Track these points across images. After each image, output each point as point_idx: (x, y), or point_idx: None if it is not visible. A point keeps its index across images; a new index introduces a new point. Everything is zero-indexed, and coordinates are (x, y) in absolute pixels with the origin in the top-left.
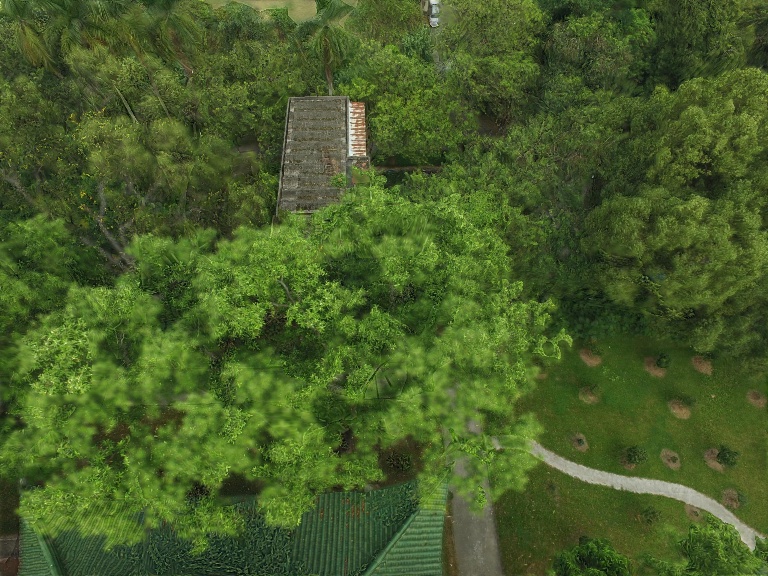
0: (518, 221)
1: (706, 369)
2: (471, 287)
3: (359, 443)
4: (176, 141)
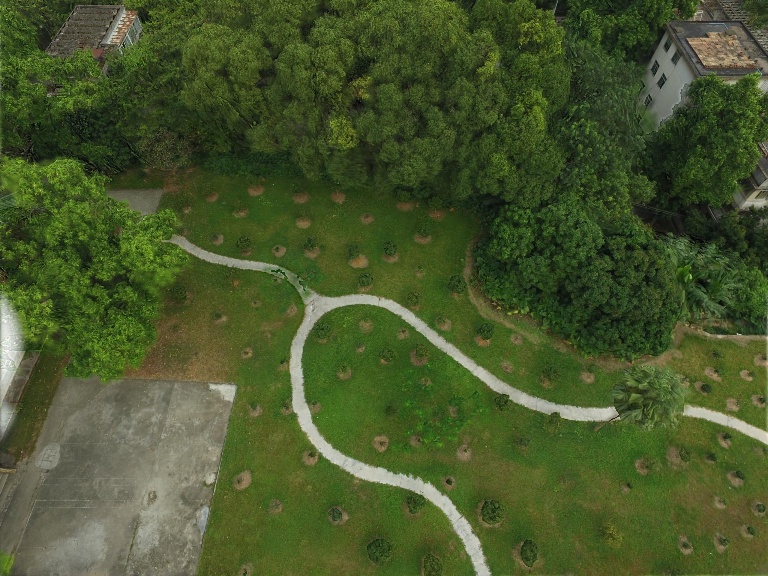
0: (158, 66)
1: (339, 200)
2: None
3: None
4: None
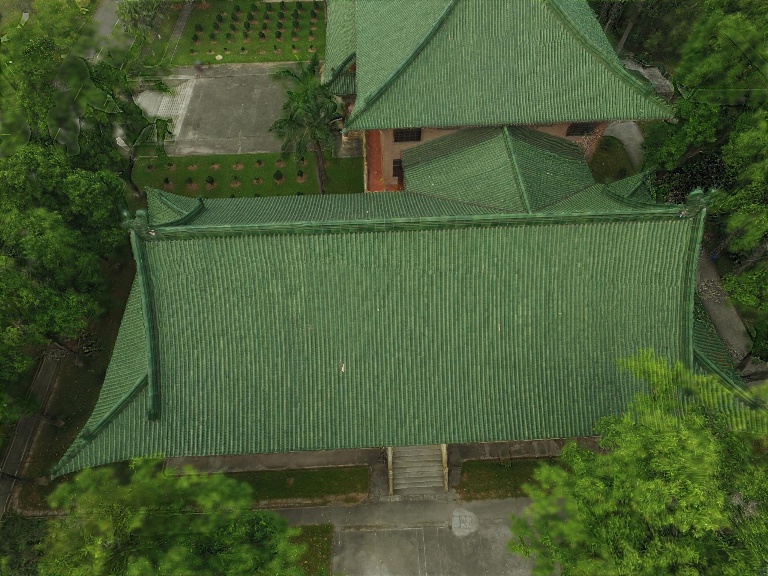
0: None
1: None
2: None
3: None
4: None
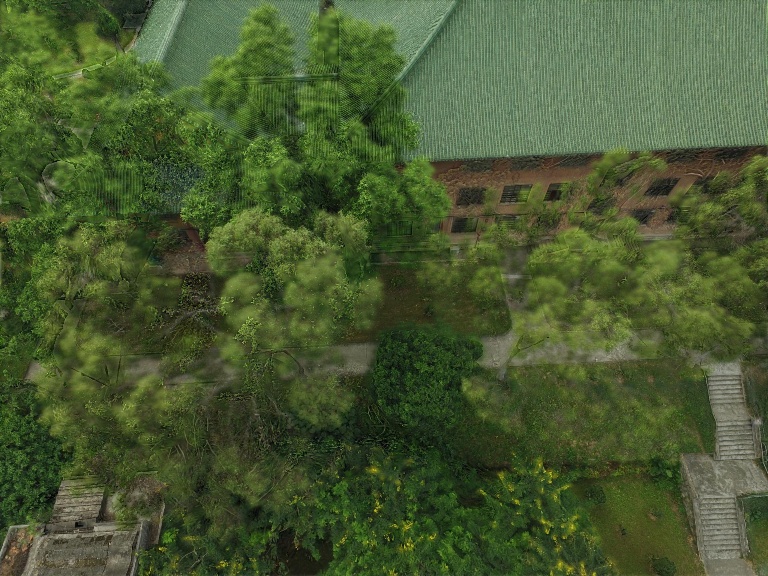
0: None
1: None
2: None
3: (147, 320)
4: None
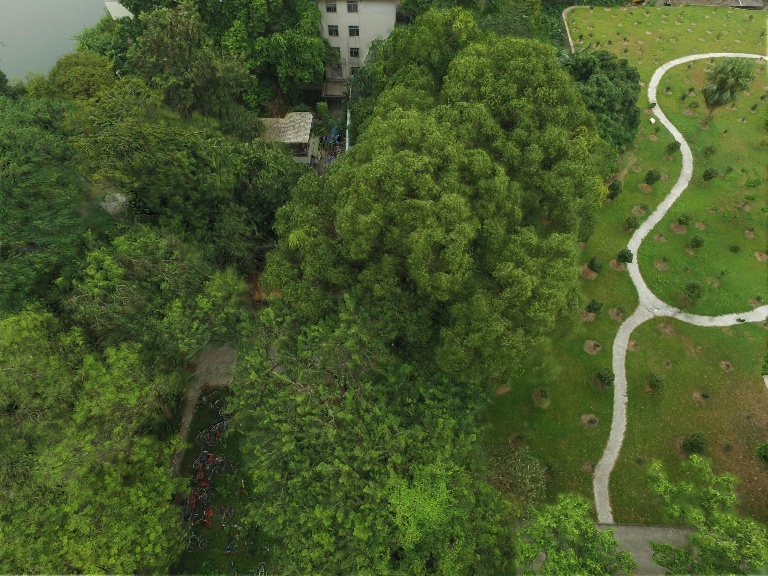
0: None
1: None
2: None
3: None
4: None
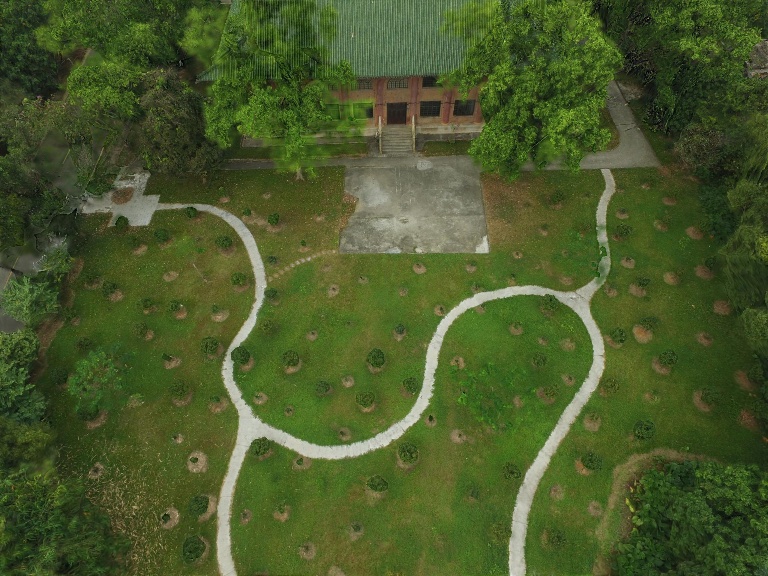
0: None
1: (719, 309)
2: (708, 0)
3: None
4: (766, 9)
